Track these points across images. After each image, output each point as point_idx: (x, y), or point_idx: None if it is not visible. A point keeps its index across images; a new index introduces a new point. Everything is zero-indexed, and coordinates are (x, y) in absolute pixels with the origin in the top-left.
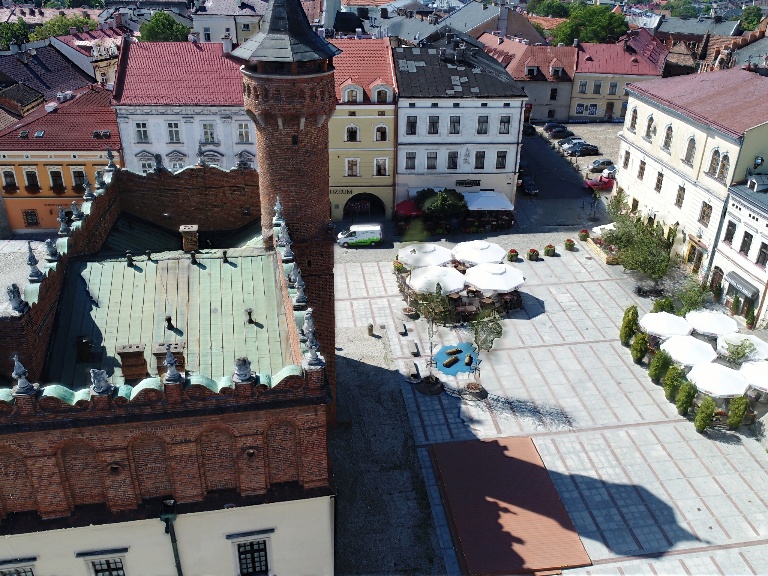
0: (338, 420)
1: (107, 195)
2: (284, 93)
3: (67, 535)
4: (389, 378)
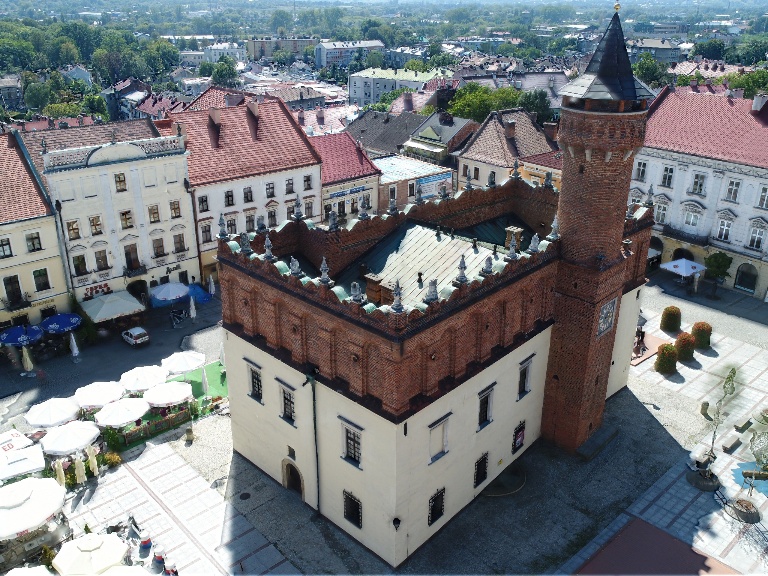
0: (578, 449)
1: (493, 193)
2: (576, 125)
3: (274, 362)
4: (672, 452)
